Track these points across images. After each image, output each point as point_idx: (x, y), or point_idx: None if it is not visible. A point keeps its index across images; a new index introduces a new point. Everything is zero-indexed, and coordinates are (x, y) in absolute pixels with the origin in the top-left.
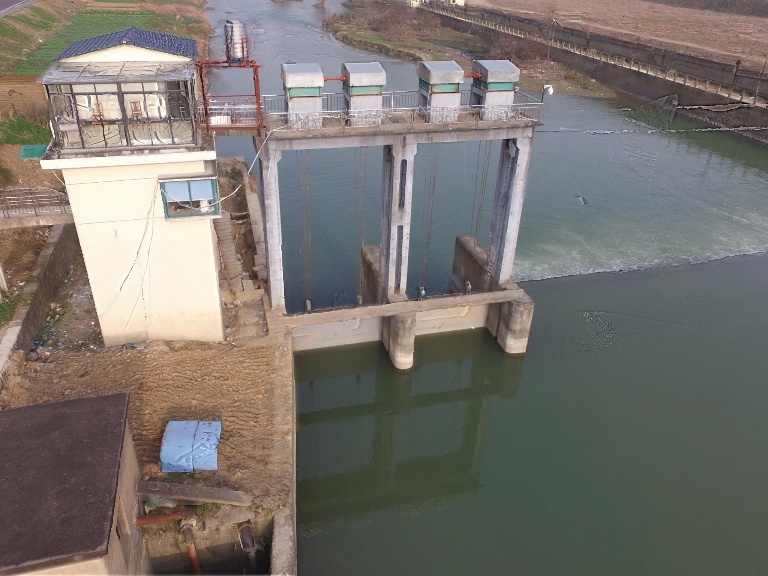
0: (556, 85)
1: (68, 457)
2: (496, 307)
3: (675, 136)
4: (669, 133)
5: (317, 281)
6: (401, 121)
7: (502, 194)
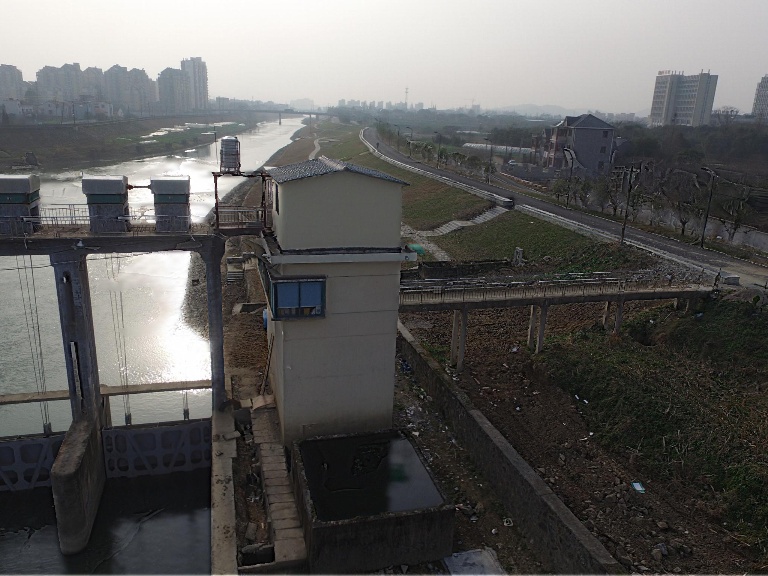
0: None
1: None
2: None
3: None
4: None
5: (138, 572)
6: (70, 228)
7: None
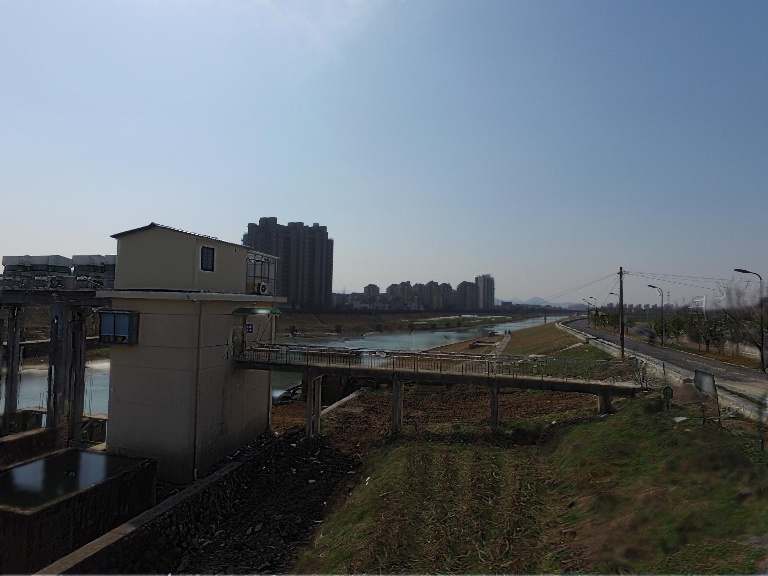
0: None
1: None
2: None
3: None
4: None
5: None
6: None
7: None
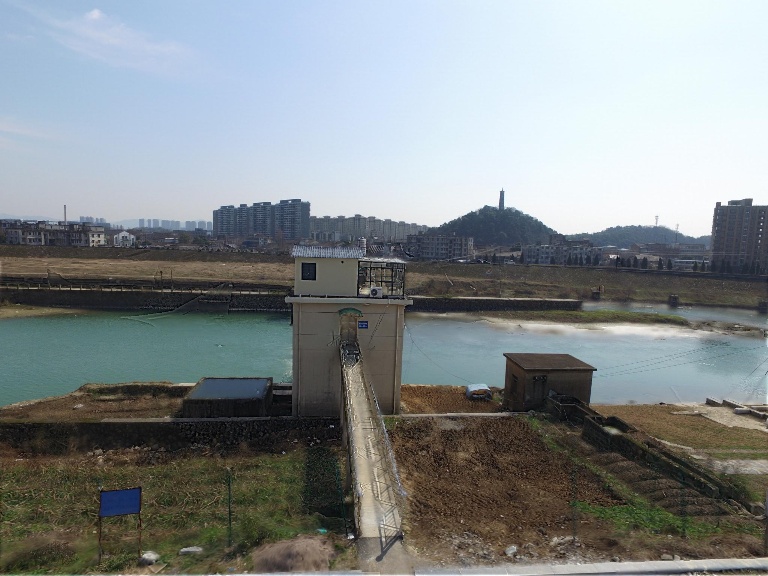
0: (1, 312)
1: (539, 357)
2: None
3: (128, 323)
4: (122, 323)
5: None
6: None
7: None
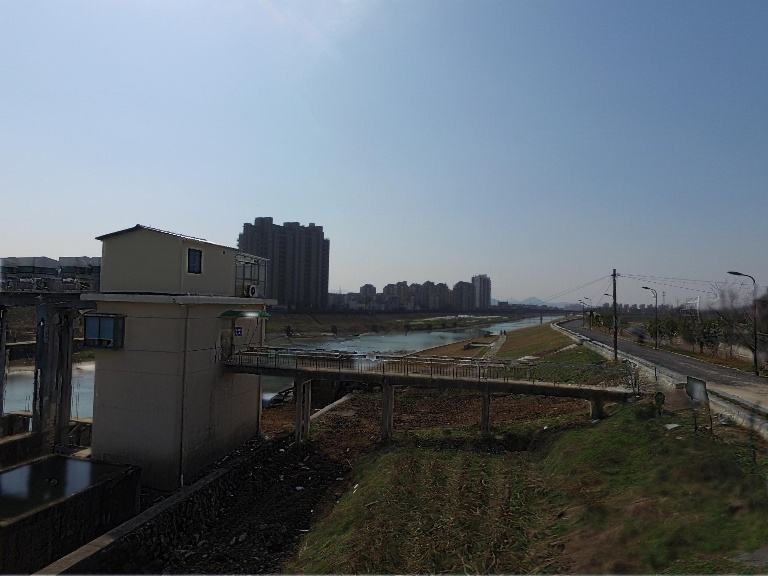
0: None
1: None
2: (4, 435)
3: None
4: None
5: None
6: None
7: None
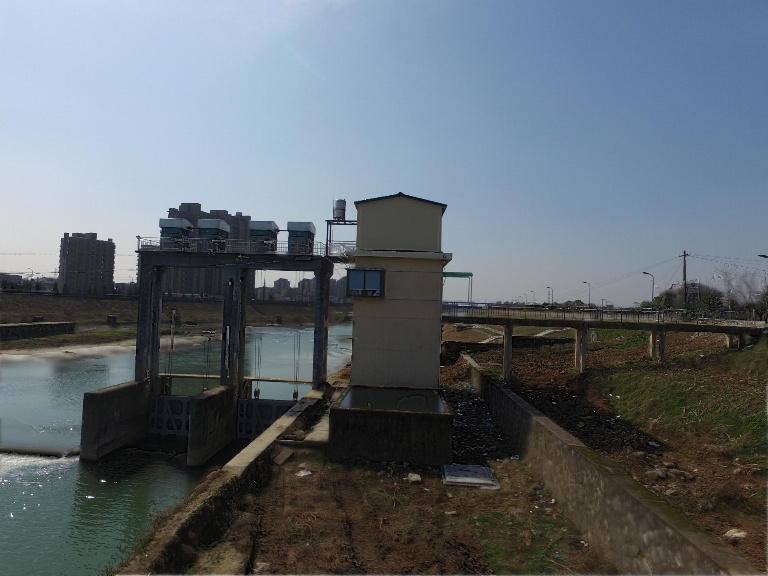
0: None
1: None
2: None
3: None
4: None
5: None
6: None
7: (152, 312)
